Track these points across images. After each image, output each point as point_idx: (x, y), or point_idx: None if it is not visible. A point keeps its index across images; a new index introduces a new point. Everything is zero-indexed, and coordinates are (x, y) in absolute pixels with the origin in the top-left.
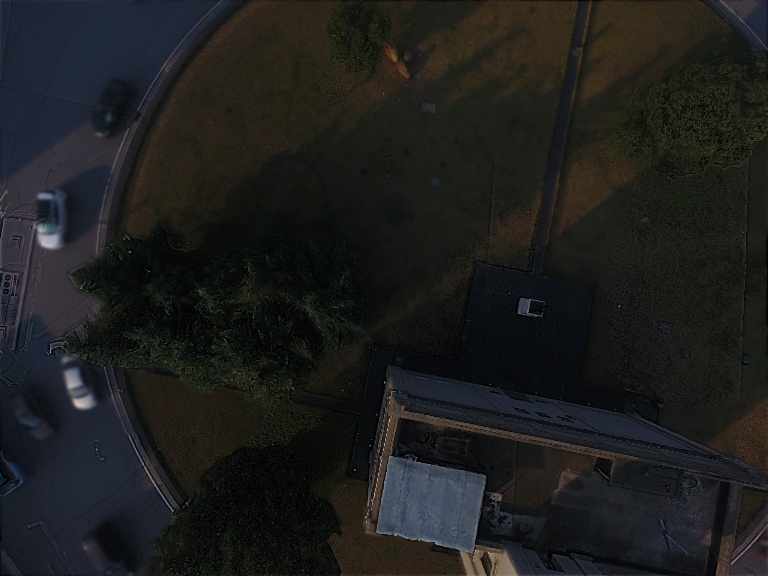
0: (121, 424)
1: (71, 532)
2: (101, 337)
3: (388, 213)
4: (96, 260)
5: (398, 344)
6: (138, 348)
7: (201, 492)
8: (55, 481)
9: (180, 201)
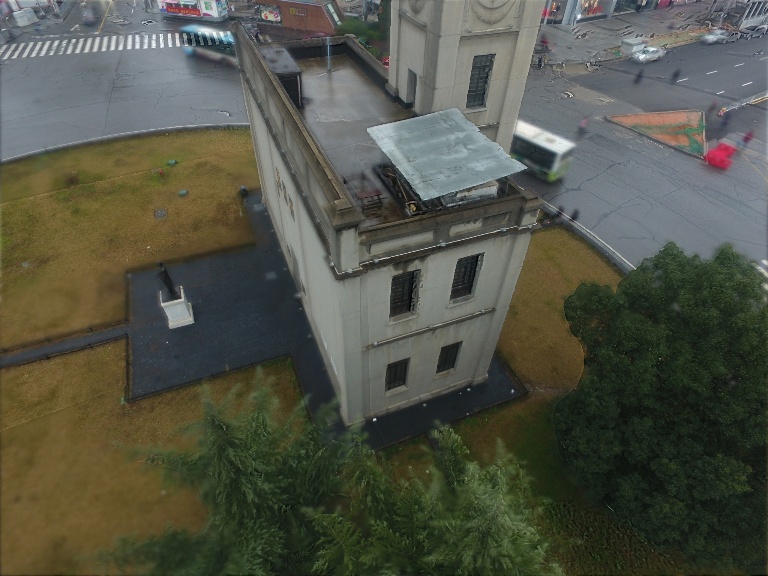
0: None
1: None
2: None
3: None
4: None
5: None
6: None
7: None
8: None
9: None
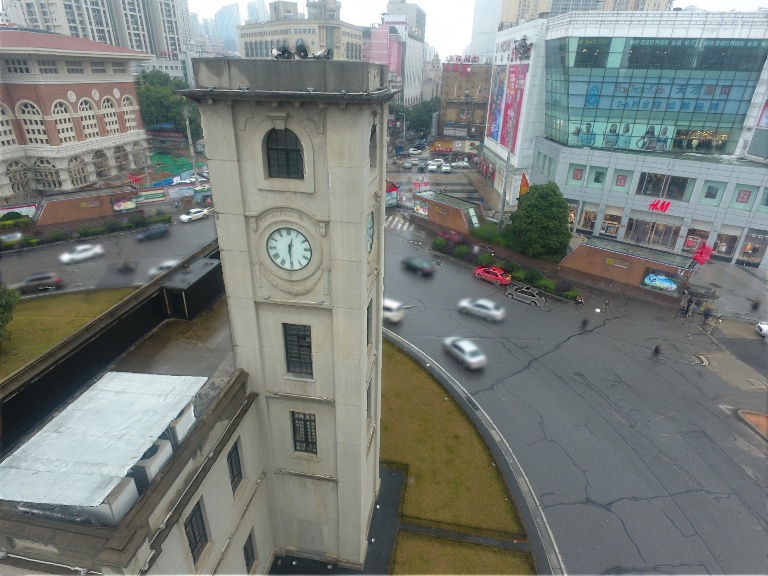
0: None
1: None
2: None
3: None
4: None
5: None
6: None
7: None
8: None
9: None
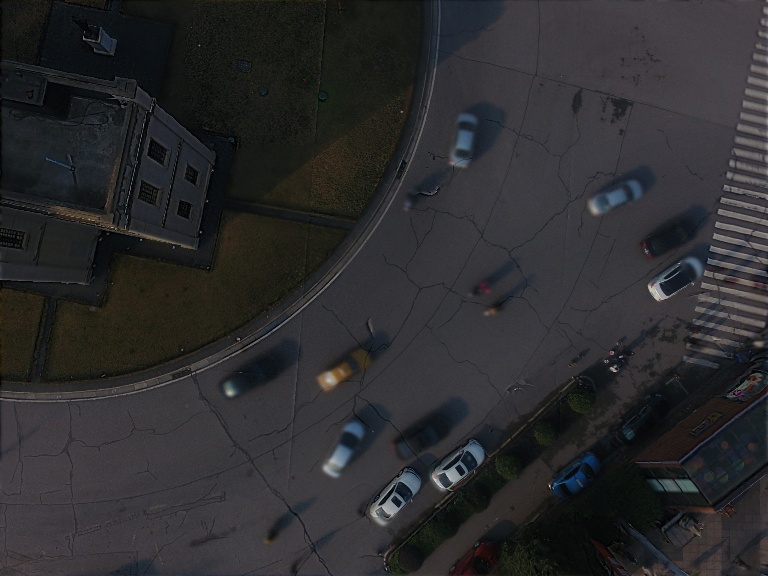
0: None
1: None
2: None
3: None
4: None
5: None
6: None
7: None
8: None
9: None
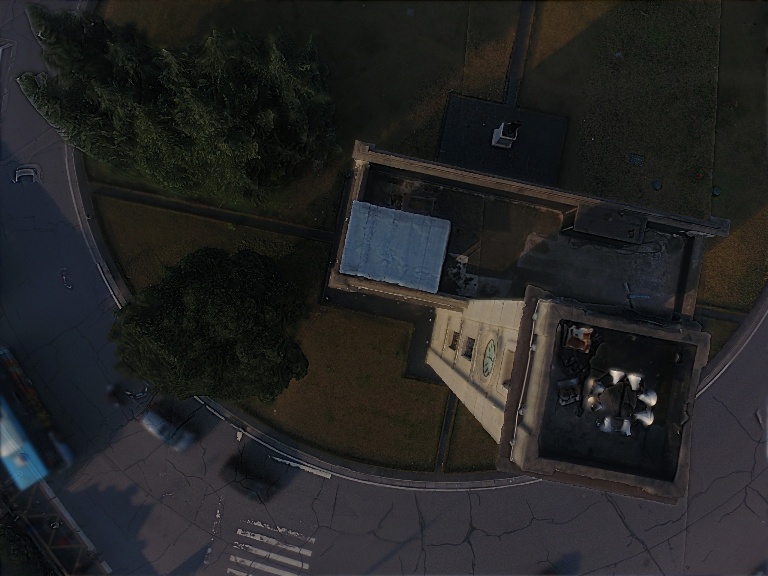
0: (89, 253)
1: (37, 360)
2: (61, 93)
3: (363, 42)
4: (56, 14)
5: None
6: (100, 115)
7: (166, 275)
8: (21, 309)
9: (151, 28)
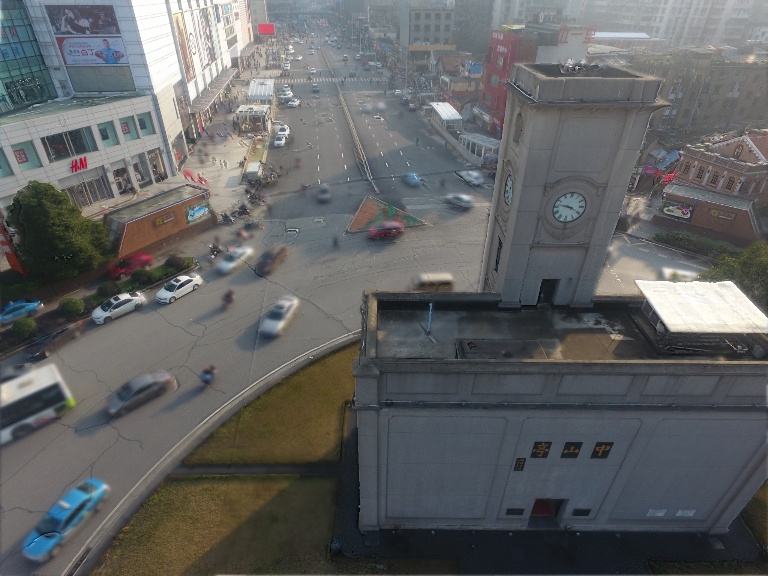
0: None
1: None
2: None
3: None
4: None
5: (740, 568)
6: None
7: None
8: None
9: None
